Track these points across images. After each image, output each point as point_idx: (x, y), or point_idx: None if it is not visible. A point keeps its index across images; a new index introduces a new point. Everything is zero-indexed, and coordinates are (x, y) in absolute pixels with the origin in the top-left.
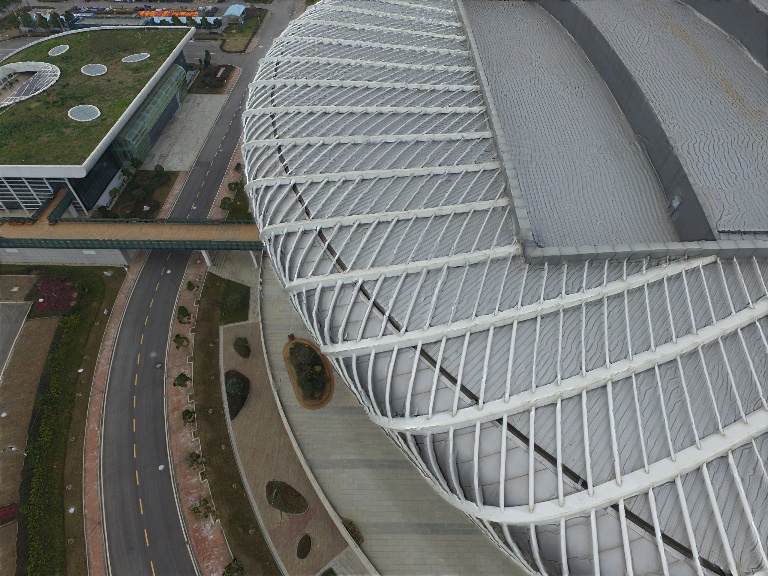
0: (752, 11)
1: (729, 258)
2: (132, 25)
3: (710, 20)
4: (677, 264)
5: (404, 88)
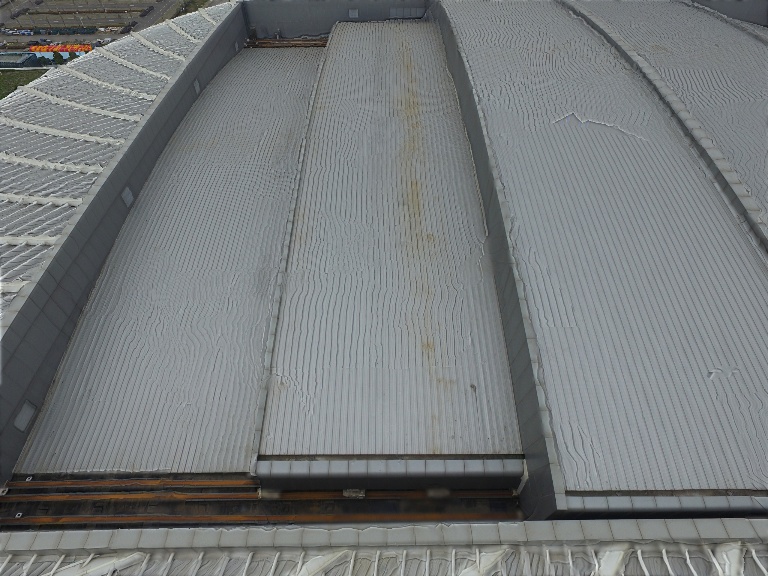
0: (469, 88)
1: (162, 556)
2: (8, 63)
3: (456, 89)
4: (64, 575)
5: (4, 202)
